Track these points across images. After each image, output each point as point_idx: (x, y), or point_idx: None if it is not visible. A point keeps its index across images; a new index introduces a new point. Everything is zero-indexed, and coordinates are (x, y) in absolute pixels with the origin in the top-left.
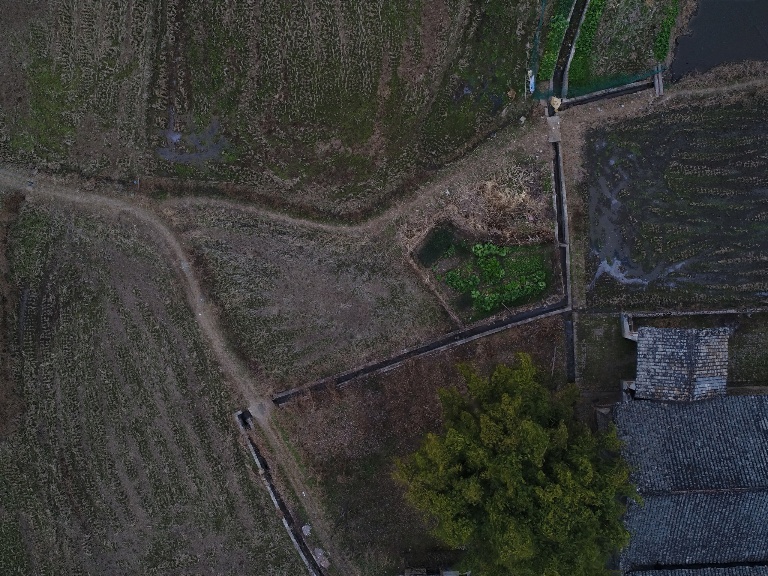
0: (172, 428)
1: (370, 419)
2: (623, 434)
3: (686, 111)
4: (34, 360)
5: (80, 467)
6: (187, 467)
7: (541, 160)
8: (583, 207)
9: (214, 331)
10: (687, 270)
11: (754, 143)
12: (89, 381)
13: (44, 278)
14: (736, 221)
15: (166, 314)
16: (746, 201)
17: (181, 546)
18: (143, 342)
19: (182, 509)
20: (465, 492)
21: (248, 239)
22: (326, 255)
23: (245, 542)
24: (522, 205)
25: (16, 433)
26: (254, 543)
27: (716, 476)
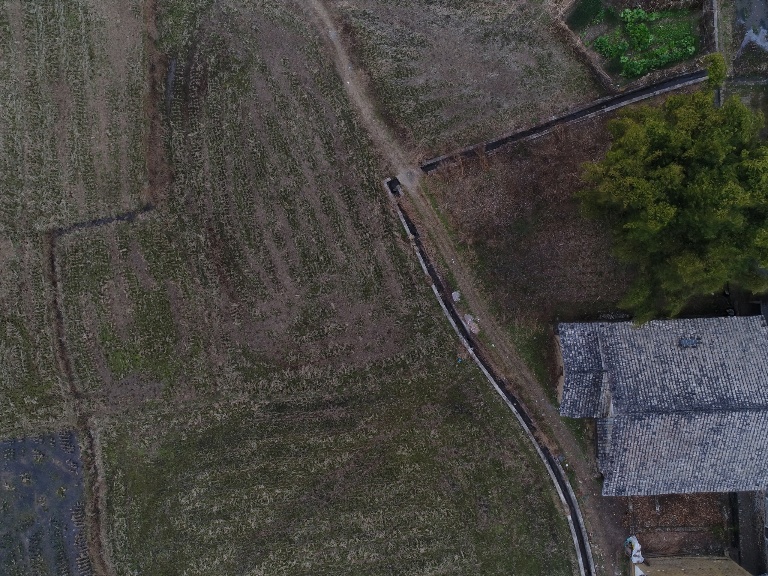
0: (321, 196)
1: (521, 181)
2: None
3: None
4: (182, 130)
5: (229, 236)
6: (336, 235)
7: None
8: None
9: (363, 99)
10: None
11: None
12: (238, 150)
13: (191, 49)
14: None
15: (314, 83)
16: None
17: (330, 314)
18: (291, 111)
19: (330, 278)
20: (665, 177)
21: (395, 9)
22: (473, 24)
23: (393, 311)
24: None
25: (165, 202)
26: (402, 312)
27: None
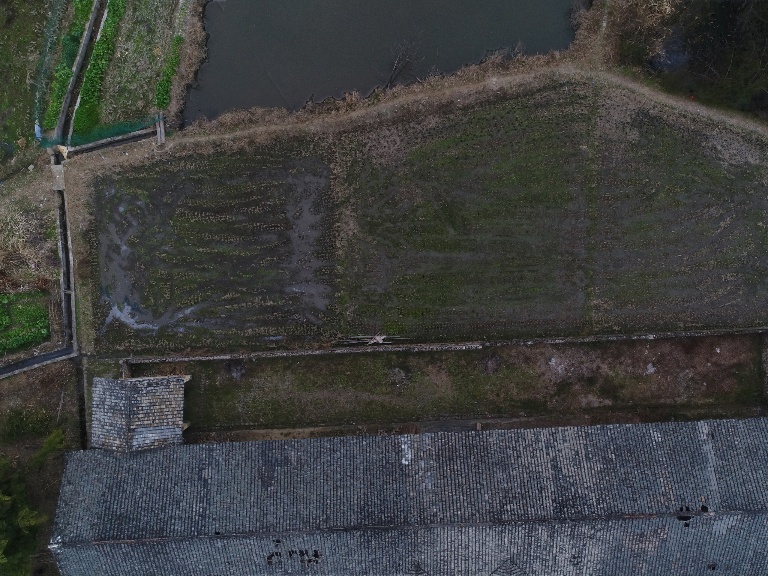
0: None
1: None
2: (66, 484)
3: (192, 158)
4: None
5: None
6: None
7: (46, 208)
8: (87, 254)
9: None
10: (196, 315)
11: (260, 189)
12: None
13: None
14: (243, 266)
15: None
16: (252, 247)
17: None
18: None
19: None
20: None
21: None
22: None
23: None
24: (20, 253)
25: None
26: None
27: (142, 526)
